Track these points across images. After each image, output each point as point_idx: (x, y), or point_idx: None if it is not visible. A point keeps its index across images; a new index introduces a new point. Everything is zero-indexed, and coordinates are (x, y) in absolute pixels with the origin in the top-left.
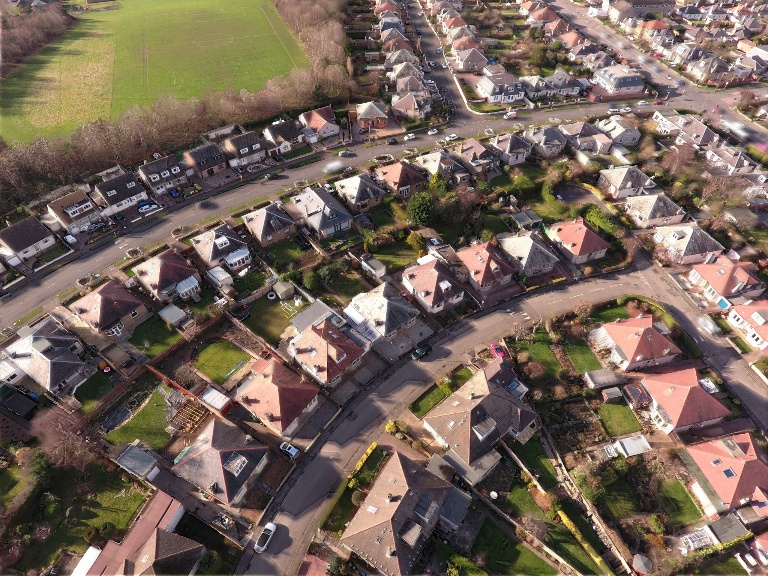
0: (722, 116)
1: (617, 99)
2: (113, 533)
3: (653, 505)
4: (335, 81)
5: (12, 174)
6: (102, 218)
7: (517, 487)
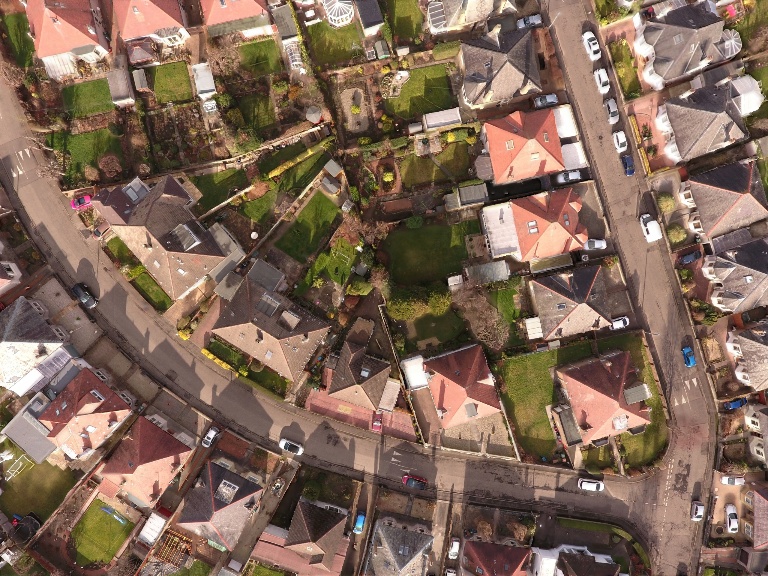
0: None
1: None
2: None
3: (263, 83)
4: None
5: None
6: None
7: (246, 211)
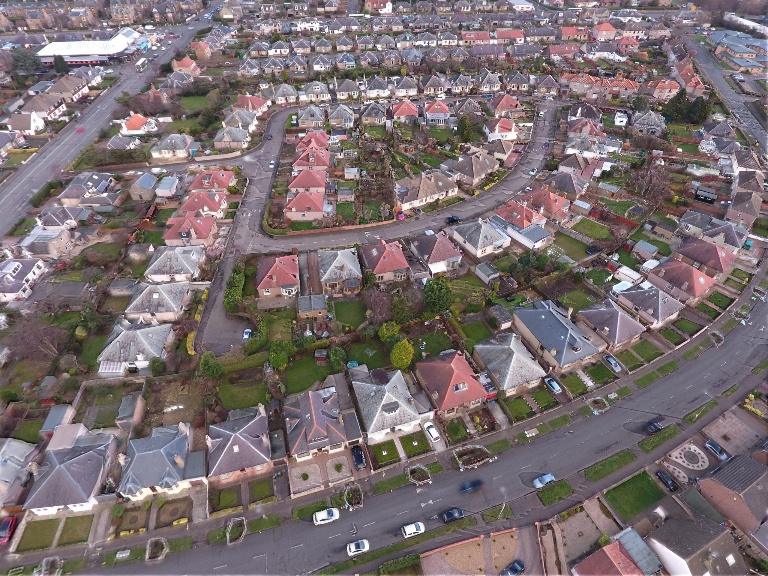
0: None
1: None
2: None
3: (357, 163)
4: None
5: None
6: None
7: None
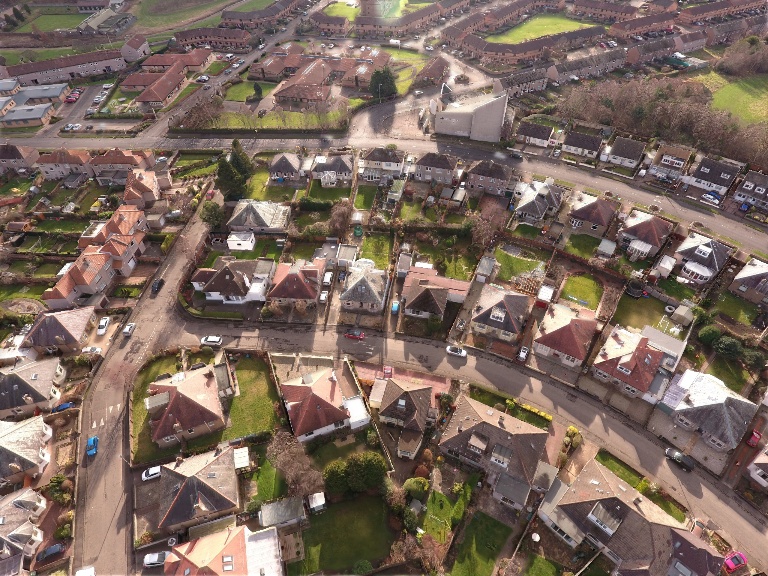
0: None
1: None
2: (442, 271)
3: None
4: None
5: (678, 118)
6: (677, 179)
7: (553, 568)
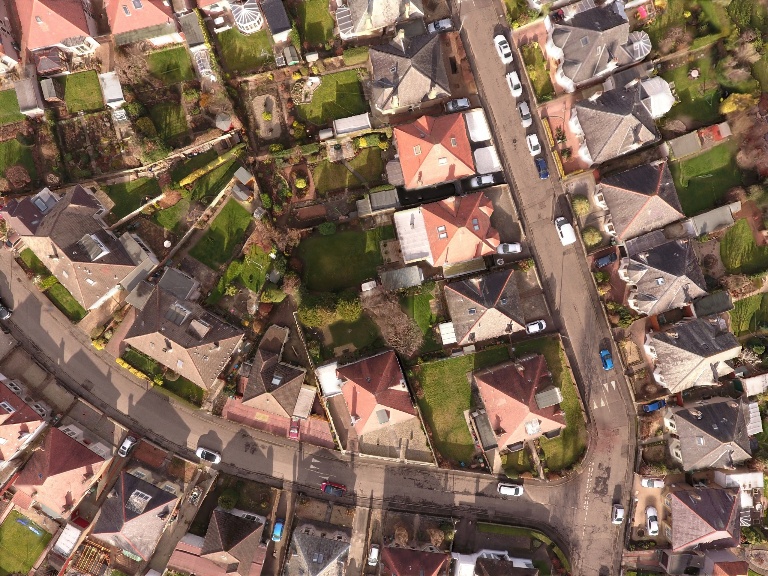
0: None
1: None
2: None
3: (174, 91)
4: None
5: None
6: None
7: (159, 220)
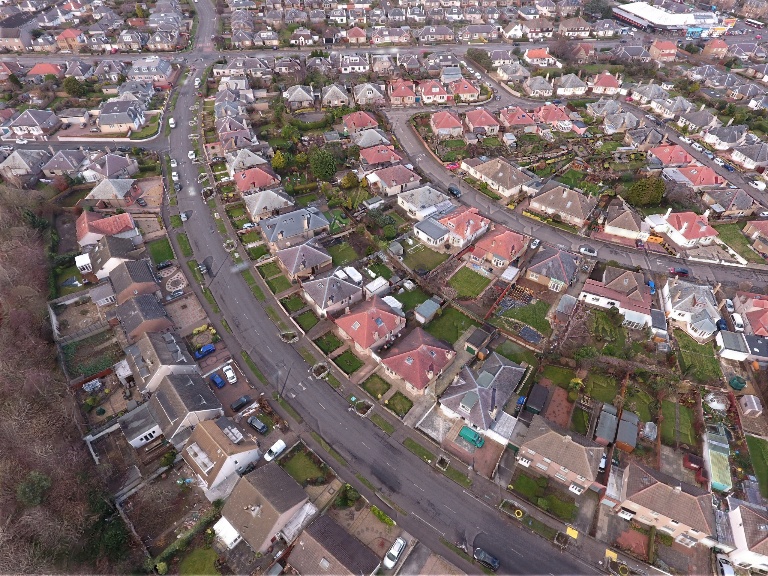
0: (229, 56)
1: (176, 80)
2: None
3: None
4: (10, 206)
5: None
6: None
7: (536, 173)
